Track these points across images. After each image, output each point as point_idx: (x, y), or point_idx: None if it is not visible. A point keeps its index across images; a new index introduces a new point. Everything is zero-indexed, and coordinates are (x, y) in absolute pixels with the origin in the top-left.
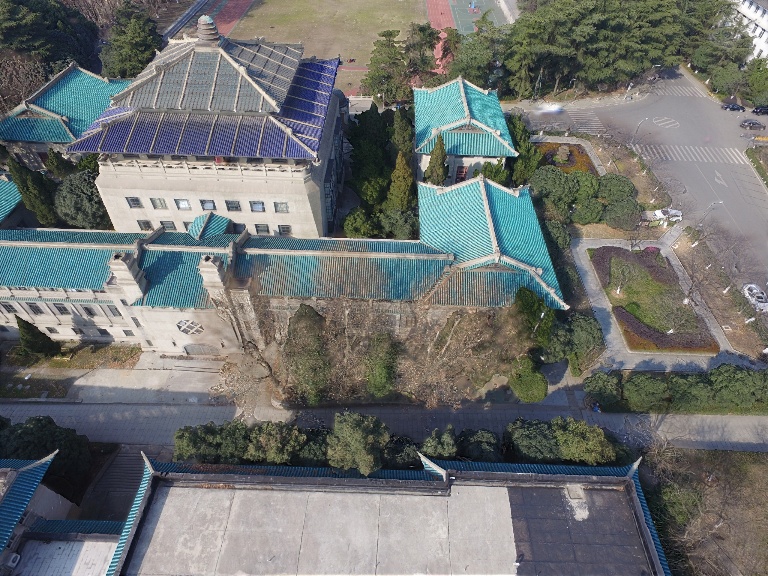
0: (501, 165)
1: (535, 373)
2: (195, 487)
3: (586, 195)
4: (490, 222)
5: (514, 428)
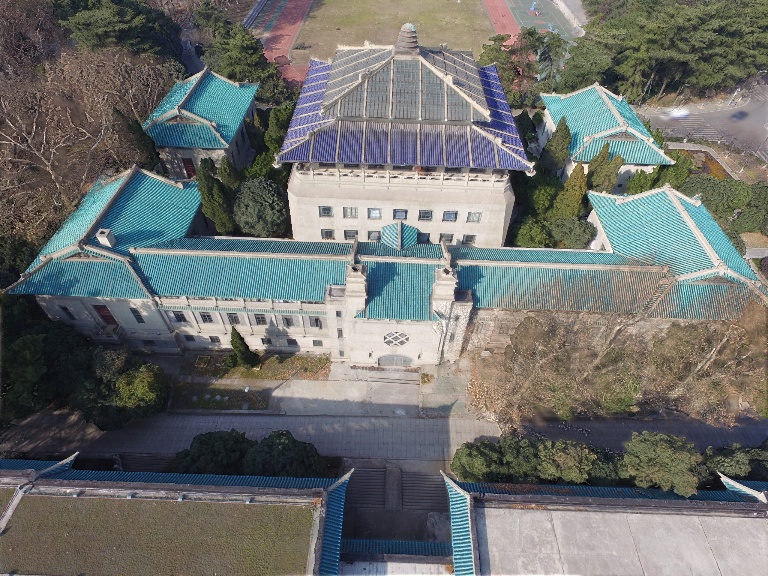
0: (656, 173)
1: None
2: (509, 508)
3: (742, 204)
4: (700, 234)
5: None
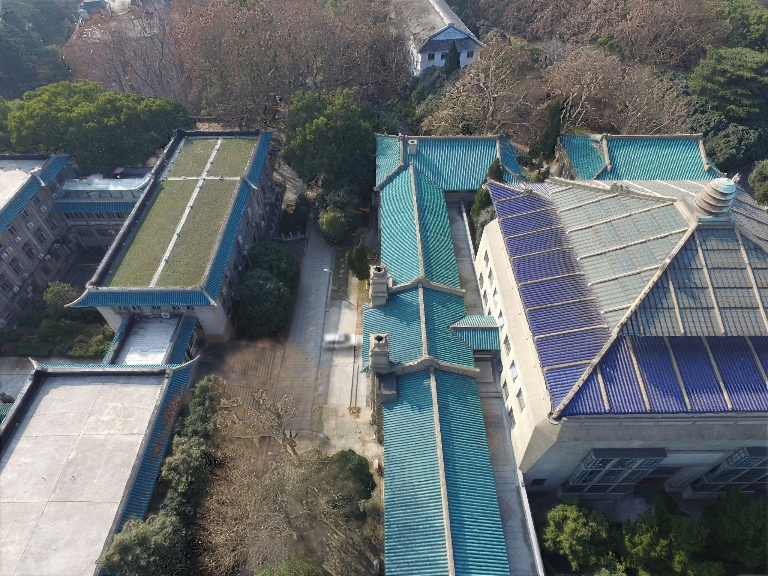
0: None
1: None
2: None
3: None
4: None
5: None
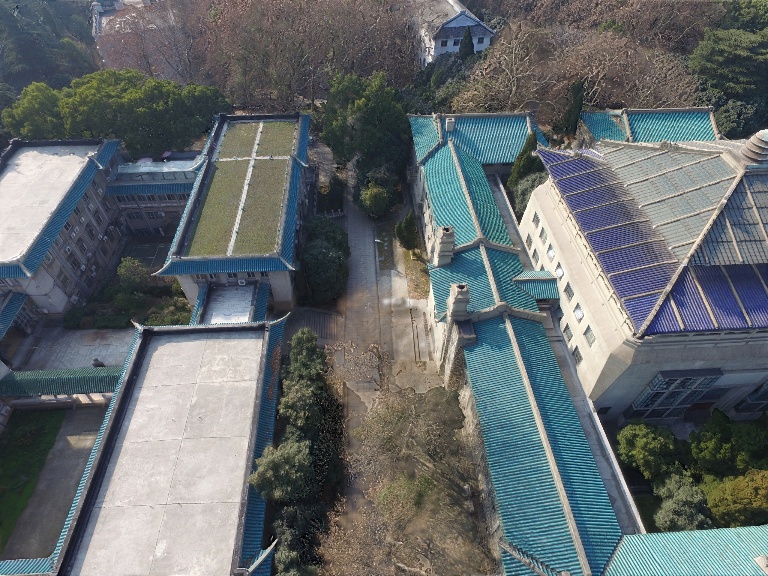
0: None
1: None
2: None
3: None
4: None
5: None
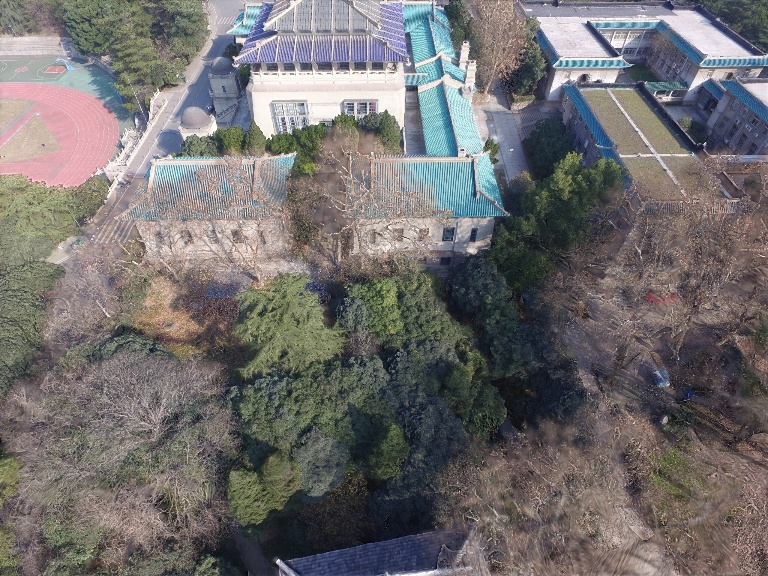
0: None
1: None
2: None
3: None
4: None
5: None
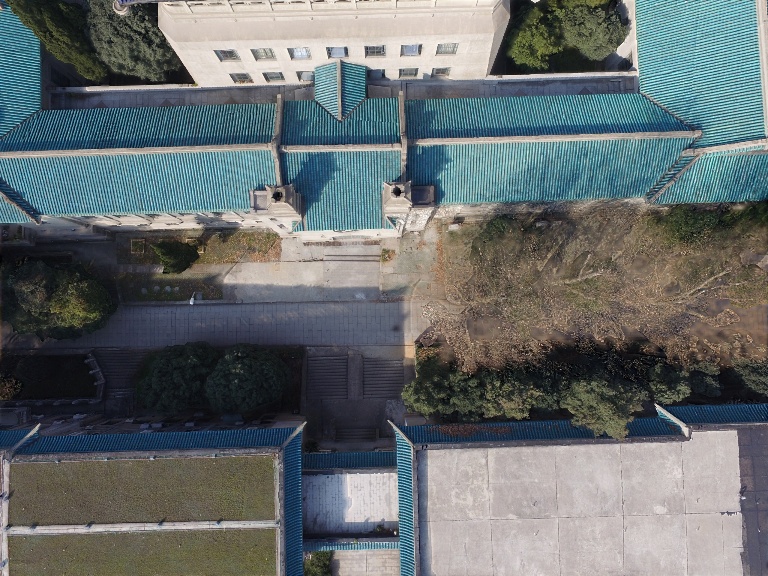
0: None
1: (764, 285)
2: (449, 448)
3: None
4: None
5: (732, 349)
